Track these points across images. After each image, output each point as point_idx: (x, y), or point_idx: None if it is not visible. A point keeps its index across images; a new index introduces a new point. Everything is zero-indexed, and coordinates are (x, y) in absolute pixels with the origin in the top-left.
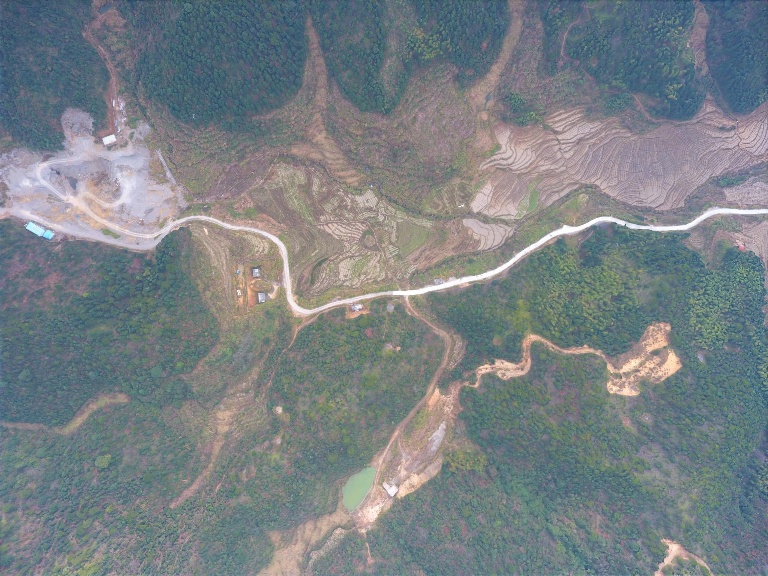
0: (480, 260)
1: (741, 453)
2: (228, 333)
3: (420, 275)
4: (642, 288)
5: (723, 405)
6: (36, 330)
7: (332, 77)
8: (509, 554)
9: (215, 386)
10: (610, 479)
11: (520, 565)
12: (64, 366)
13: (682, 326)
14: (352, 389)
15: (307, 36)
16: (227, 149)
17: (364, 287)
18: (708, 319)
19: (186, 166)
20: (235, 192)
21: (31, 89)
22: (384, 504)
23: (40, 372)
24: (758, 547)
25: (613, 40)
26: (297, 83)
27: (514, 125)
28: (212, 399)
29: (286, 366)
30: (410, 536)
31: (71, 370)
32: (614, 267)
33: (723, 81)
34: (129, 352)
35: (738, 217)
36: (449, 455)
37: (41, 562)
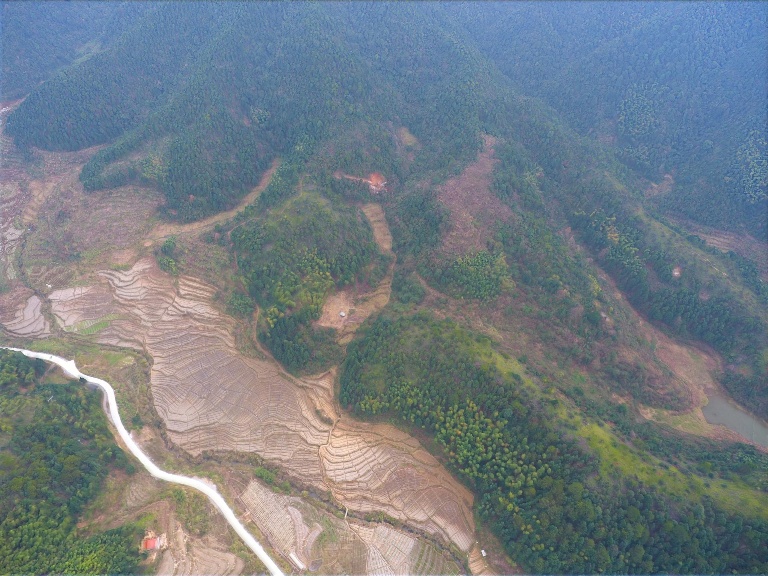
0: None
1: None
2: None
3: None
4: None
5: None
6: None
7: None
8: None
9: None
10: None
11: None
12: None
13: None
14: None
15: (120, 137)
16: (6, 155)
17: None
18: None
19: None
20: None
21: None
22: None
23: None
24: None
25: (269, 246)
26: (72, 144)
27: (159, 264)
28: None
29: None
30: None
31: None
32: (5, 407)
33: None
34: None
35: (220, 522)
36: None
37: None
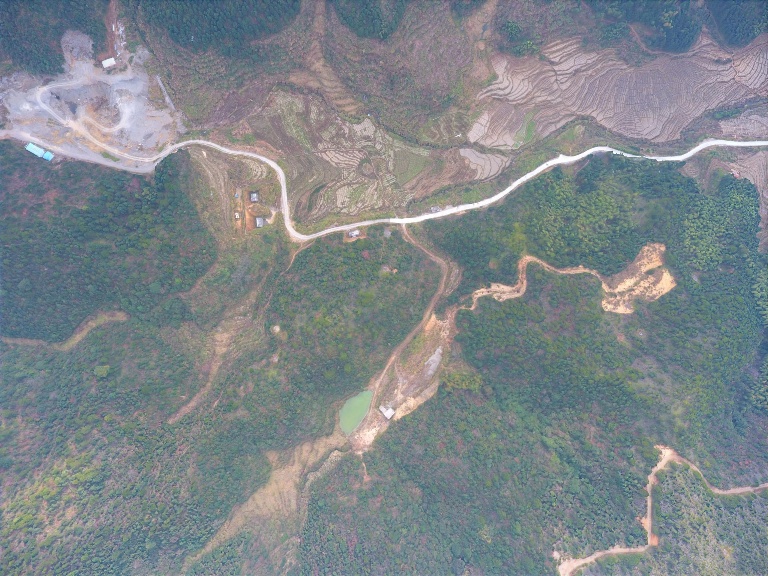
0: (477, 189)
1: (734, 365)
2: (226, 253)
3: (417, 203)
4: (637, 211)
5: (717, 318)
6: (36, 239)
7: (330, 3)
8: (504, 464)
9: (213, 307)
10: (604, 389)
11: (515, 474)
12: (63, 278)
13: (677, 247)
14: (349, 306)
15: None
16: (226, 75)
17: (361, 214)
18: (702, 241)
19: (185, 92)
20: (233, 119)
21: (31, 8)
22: (381, 427)
23: (39, 283)
24: (751, 457)
25: None
26: (295, 7)
27: (511, 55)
28: (210, 321)
29: (284, 287)
30: (406, 454)
31: (70, 283)
32: (609, 191)
33: (719, 12)
34: (128, 265)
35: (733, 148)
36: (445, 376)
37: (40, 466)
